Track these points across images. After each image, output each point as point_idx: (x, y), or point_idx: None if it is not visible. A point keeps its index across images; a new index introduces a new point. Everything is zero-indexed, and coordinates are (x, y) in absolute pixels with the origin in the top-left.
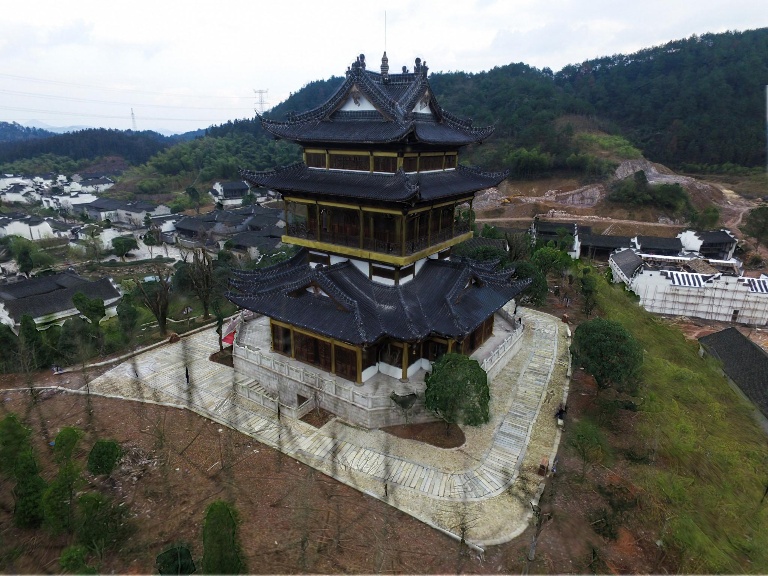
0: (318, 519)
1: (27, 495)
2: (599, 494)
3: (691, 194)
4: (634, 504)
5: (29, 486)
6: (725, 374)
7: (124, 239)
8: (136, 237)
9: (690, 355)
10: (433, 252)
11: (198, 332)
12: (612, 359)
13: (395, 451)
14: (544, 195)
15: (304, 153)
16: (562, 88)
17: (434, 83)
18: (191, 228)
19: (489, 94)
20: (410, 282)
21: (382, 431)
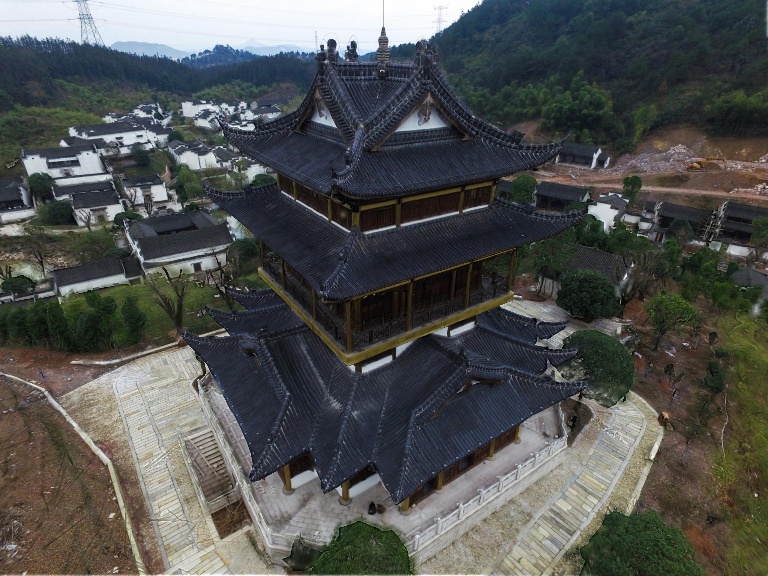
0: None
1: None
2: None
3: None
4: None
5: None
6: None
7: (264, 176)
8: None
9: None
10: (416, 337)
11: None
12: None
13: None
14: (758, 160)
15: None
16: None
17: None
18: None
19: (714, 8)
20: (385, 366)
21: (285, 573)
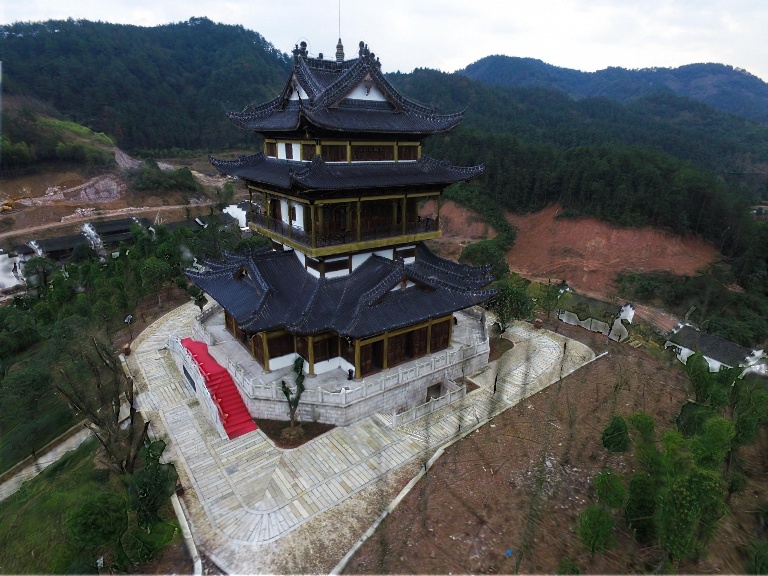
0: (605, 387)
1: None
2: (579, 310)
3: None
4: None
5: None
6: None
7: None
8: None
9: None
10: None
11: None
12: (503, 260)
13: (515, 362)
14: (46, 194)
15: (319, 146)
16: None
17: None
18: None
19: None
20: None
21: (491, 362)
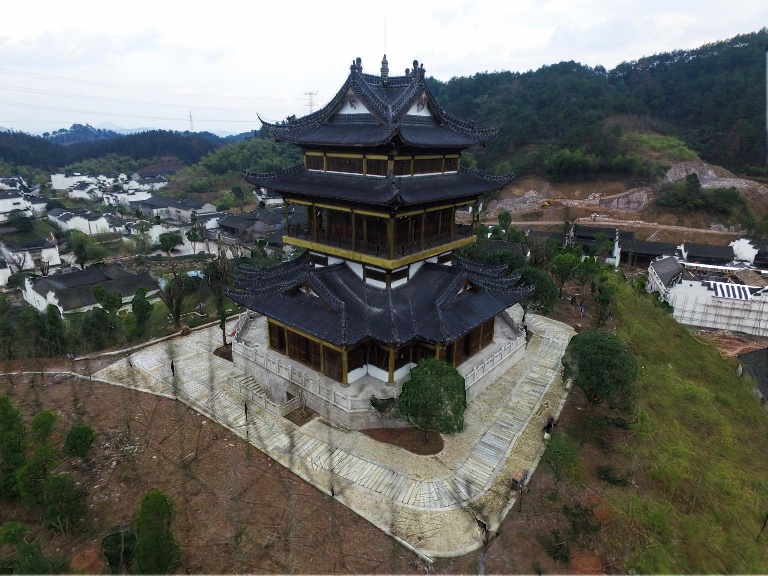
0: (273, 516)
1: (9, 471)
2: (563, 514)
3: (751, 199)
4: (597, 528)
5: (11, 463)
6: (763, 395)
7: (170, 235)
8: (182, 233)
9: (719, 373)
10: (427, 256)
11: (210, 326)
12: (602, 373)
13: (369, 454)
14: (587, 198)
15: None
16: (615, 86)
17: (479, 83)
18: (233, 226)
19: (535, 94)
20: (404, 285)
21: (361, 433)
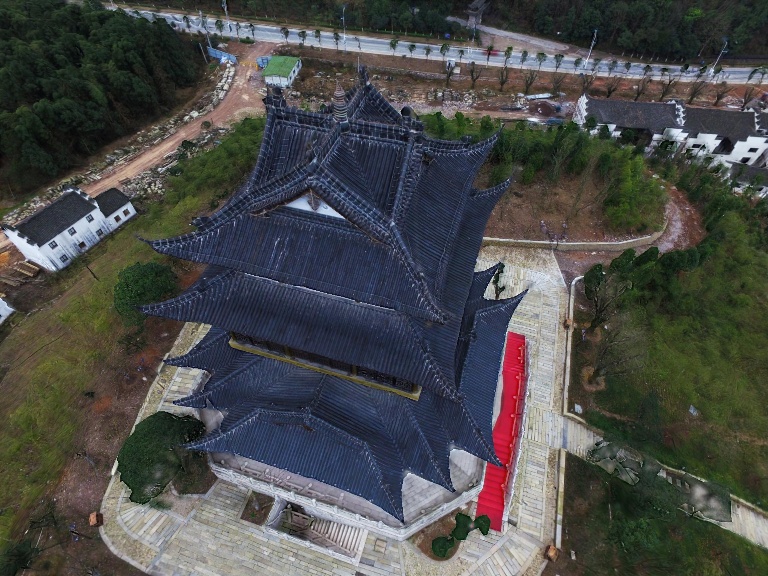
0: None
1: None
2: None
3: None
4: None
5: None
6: None
7: None
8: None
9: None
10: None
11: None
12: None
13: None
14: None
15: None
16: None
17: None
18: None
19: None
20: None
21: None
